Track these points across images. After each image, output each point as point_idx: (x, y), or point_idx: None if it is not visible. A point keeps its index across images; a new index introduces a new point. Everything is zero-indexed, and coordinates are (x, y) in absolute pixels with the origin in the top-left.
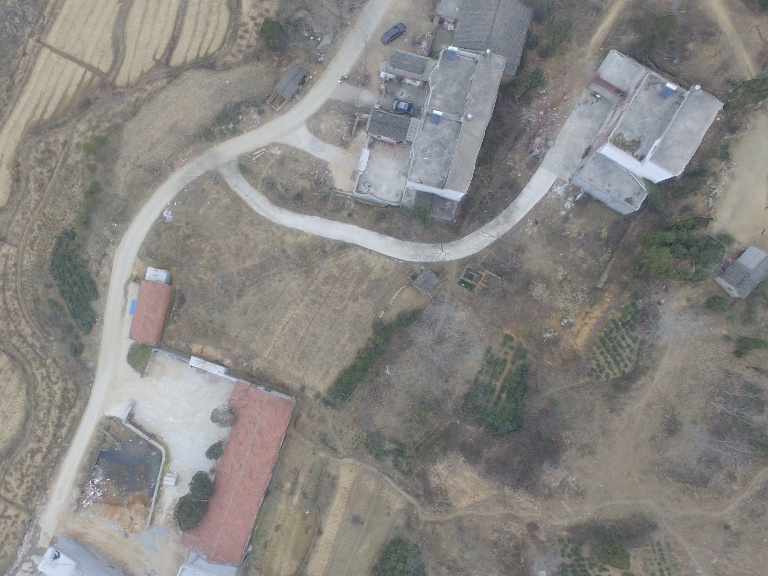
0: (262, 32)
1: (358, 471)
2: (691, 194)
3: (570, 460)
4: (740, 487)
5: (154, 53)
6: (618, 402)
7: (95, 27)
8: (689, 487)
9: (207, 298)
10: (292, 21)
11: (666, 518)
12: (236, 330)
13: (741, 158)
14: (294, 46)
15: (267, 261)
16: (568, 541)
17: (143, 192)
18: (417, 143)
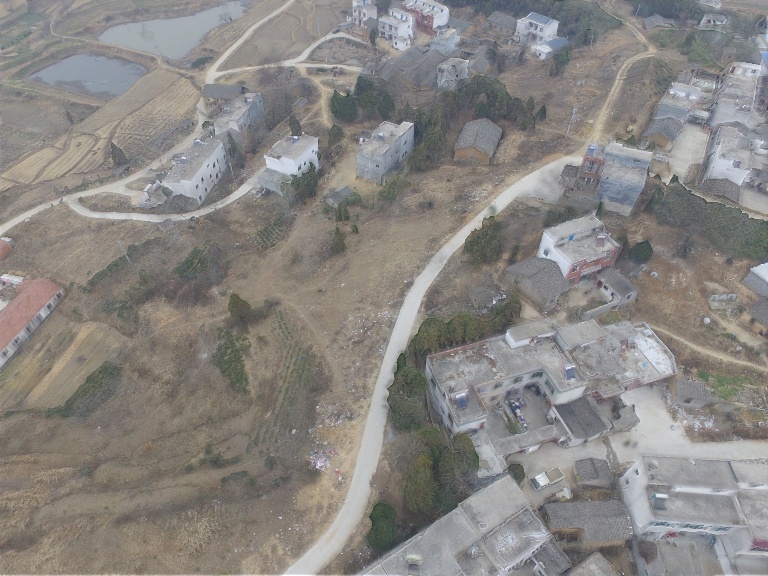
0: (112, 153)
1: (94, 327)
2: (318, 180)
3: (230, 282)
4: (328, 269)
5: (57, 175)
6: (264, 252)
7: (31, 170)
8: (301, 280)
9: (31, 248)
10: (134, 158)
11: (287, 299)
12: (42, 260)
13: (342, 166)
14: (132, 166)
15: (77, 231)
16: (224, 328)
17: (18, 213)
18: (173, 171)
